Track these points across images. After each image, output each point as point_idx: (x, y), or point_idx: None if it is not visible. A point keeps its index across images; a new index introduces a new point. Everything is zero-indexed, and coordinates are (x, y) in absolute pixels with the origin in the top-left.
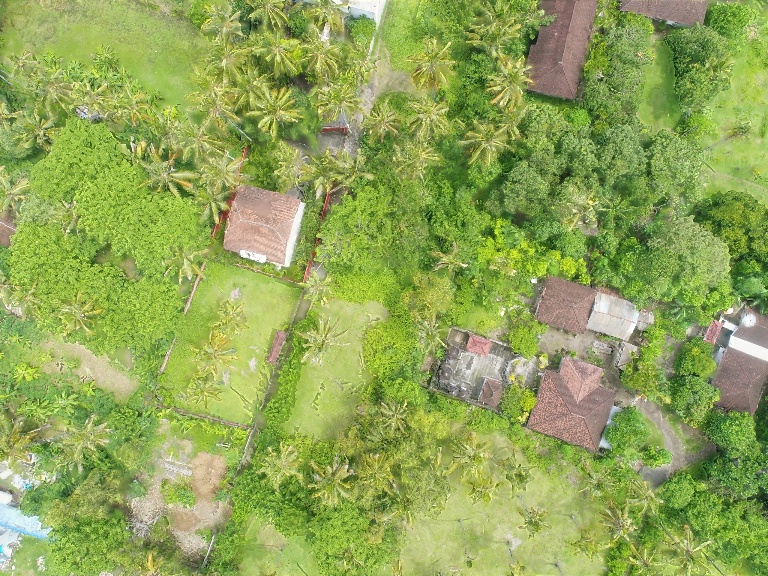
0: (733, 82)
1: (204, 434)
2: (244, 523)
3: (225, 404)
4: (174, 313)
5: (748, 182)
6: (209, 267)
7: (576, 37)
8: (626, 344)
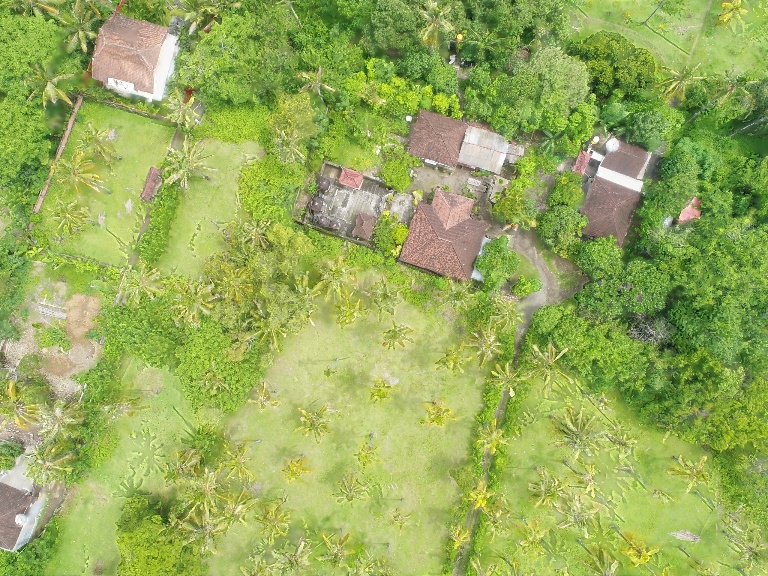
0: None
1: (78, 275)
2: (117, 362)
3: (101, 247)
4: (38, 137)
5: (620, 26)
6: (84, 108)
7: None
8: (498, 177)
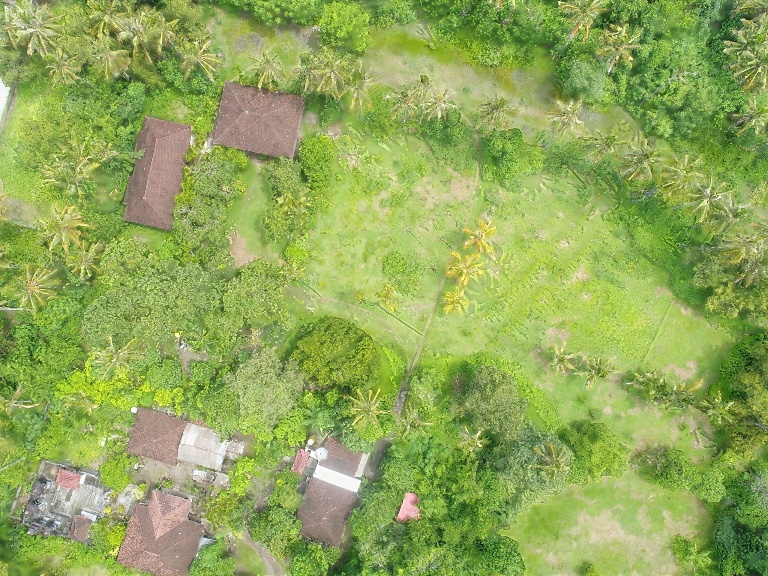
0: (336, 209)
1: None
2: None
3: None
4: None
5: (354, 306)
6: None
7: (164, 171)
8: (218, 474)
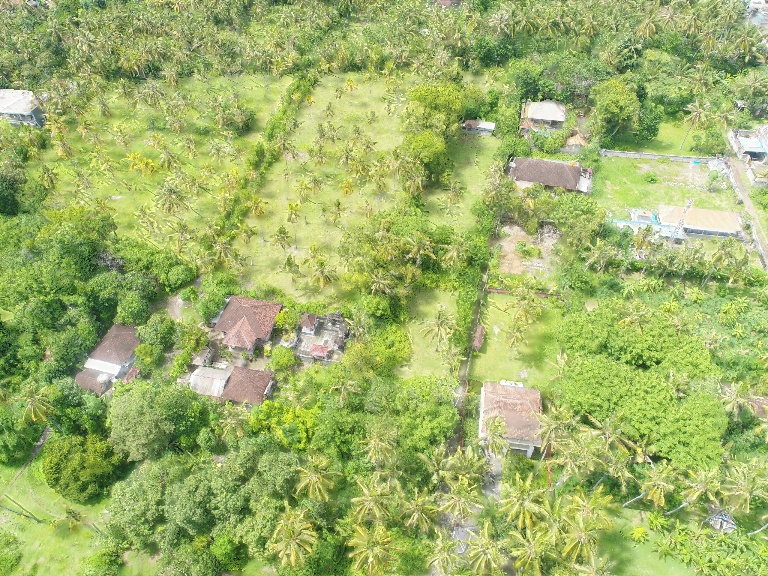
0: None
1: None
2: None
3: None
4: None
5: None
6: None
7: None
8: (201, 364)
